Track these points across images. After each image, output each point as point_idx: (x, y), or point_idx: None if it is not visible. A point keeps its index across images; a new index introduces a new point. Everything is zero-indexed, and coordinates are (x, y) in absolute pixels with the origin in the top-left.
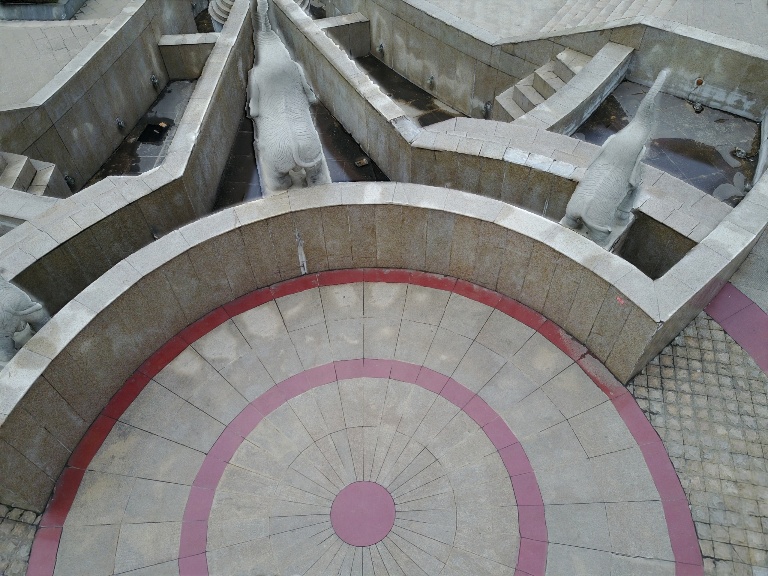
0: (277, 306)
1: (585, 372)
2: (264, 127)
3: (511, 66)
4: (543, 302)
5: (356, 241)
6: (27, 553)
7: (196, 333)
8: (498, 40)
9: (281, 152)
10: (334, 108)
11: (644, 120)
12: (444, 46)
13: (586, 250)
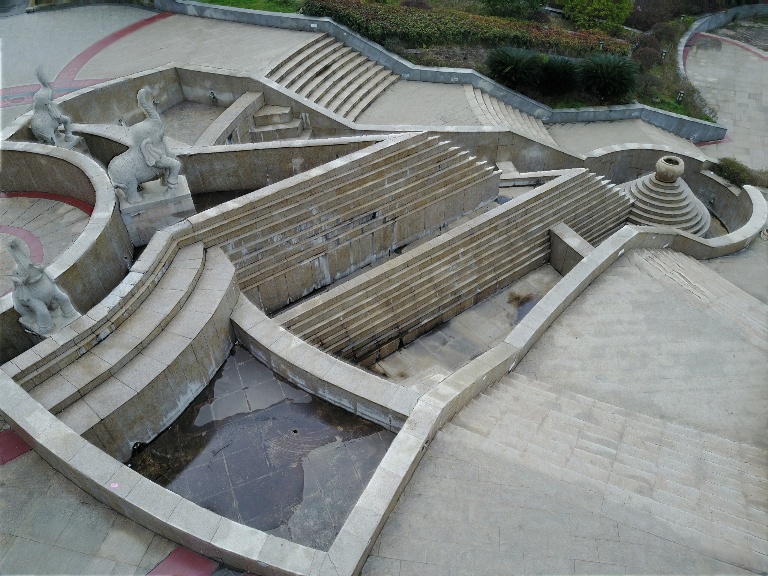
0: None
1: None
2: None
3: None
4: None
5: None
6: None
7: (84, 207)
8: (513, 345)
9: None
10: None
11: None
12: None
13: (9, 301)
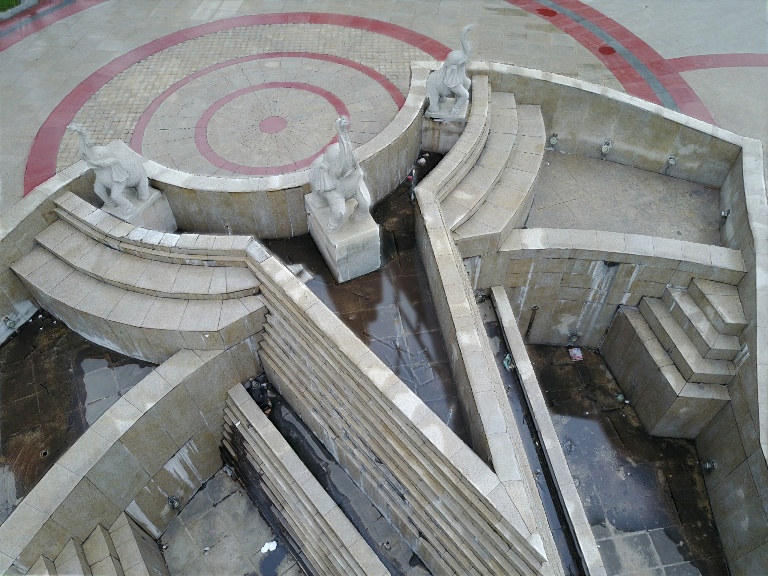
0: None
1: None
2: None
3: None
4: None
5: None
6: None
7: None
8: None
9: None
10: None
11: None
12: None
13: None
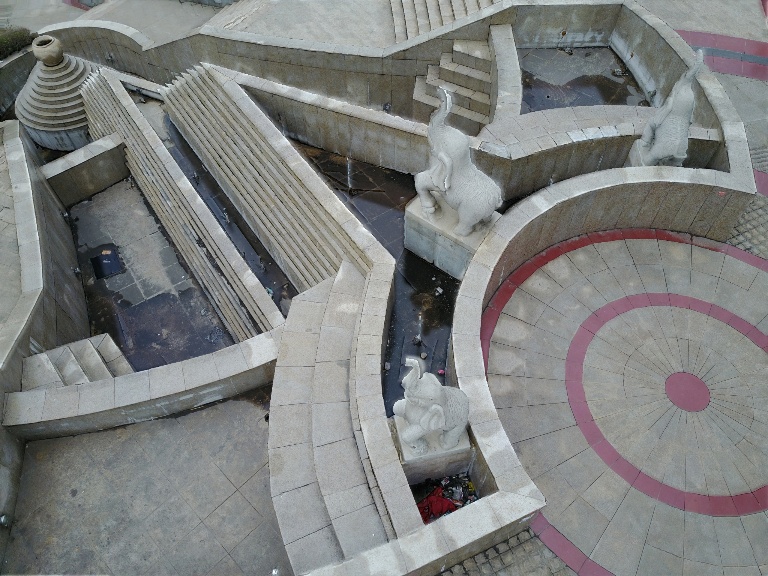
0: (508, 315)
1: (701, 247)
2: (468, 192)
3: (404, 68)
4: (653, 220)
5: (530, 242)
6: (551, 553)
7: None
8: (383, 51)
9: (490, 203)
10: (381, 159)
11: (690, 82)
12: (330, 72)
13: (684, 174)
